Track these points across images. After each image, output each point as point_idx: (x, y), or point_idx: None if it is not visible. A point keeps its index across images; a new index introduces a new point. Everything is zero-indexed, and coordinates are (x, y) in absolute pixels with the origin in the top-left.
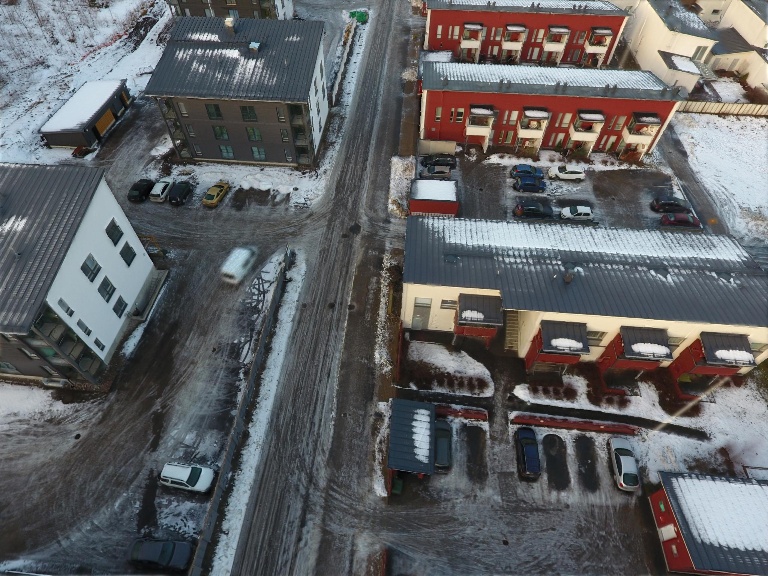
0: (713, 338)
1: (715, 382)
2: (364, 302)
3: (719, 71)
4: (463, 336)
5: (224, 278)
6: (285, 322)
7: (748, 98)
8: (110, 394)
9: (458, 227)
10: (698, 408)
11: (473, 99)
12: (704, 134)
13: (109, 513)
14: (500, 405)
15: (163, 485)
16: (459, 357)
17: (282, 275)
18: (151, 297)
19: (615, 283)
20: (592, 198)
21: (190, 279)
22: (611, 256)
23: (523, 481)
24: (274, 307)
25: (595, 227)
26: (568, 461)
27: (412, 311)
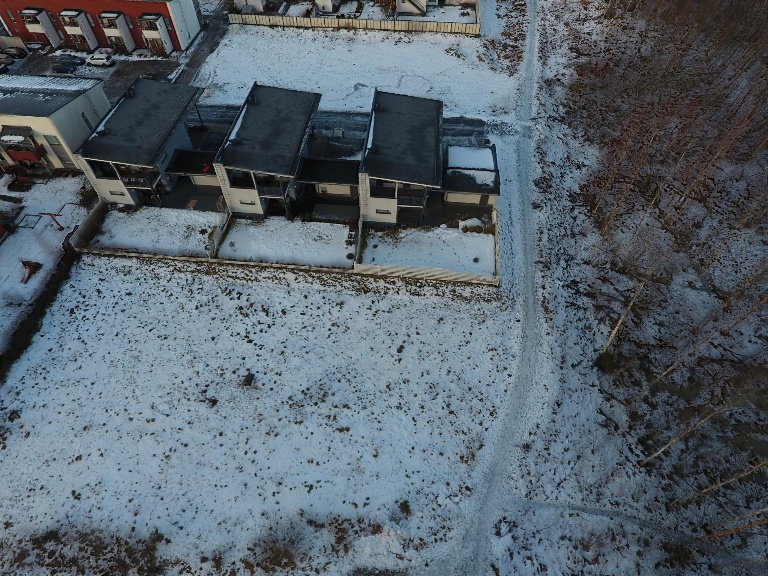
0: (9, 130)
1: (58, 174)
2: None
3: None
4: None
5: None
6: None
7: (305, 15)
8: None
9: None
10: (31, 187)
11: (26, 2)
12: (245, 39)
13: None
14: None
15: None
16: None
17: None
18: None
19: None
20: (106, 77)
21: None
22: None
23: None
24: None
25: None
26: None
27: None
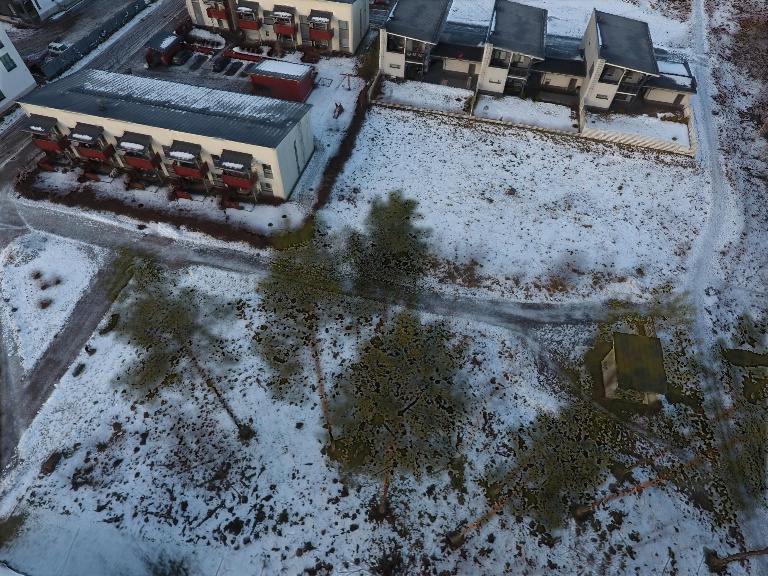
0: (316, 13)
1: (335, 54)
2: (182, 16)
3: None
4: (222, 29)
5: (115, 2)
6: (137, 19)
7: None
8: (39, 29)
9: None
10: (318, 61)
11: None
12: None
13: (24, 58)
14: (223, 52)
15: (51, 54)
16: (214, 35)
17: (144, 1)
18: (73, 2)
19: None
20: None
21: (97, 0)
22: None
23: (214, 72)
24: (134, 12)
25: None
26: (240, 69)
27: (192, 7)
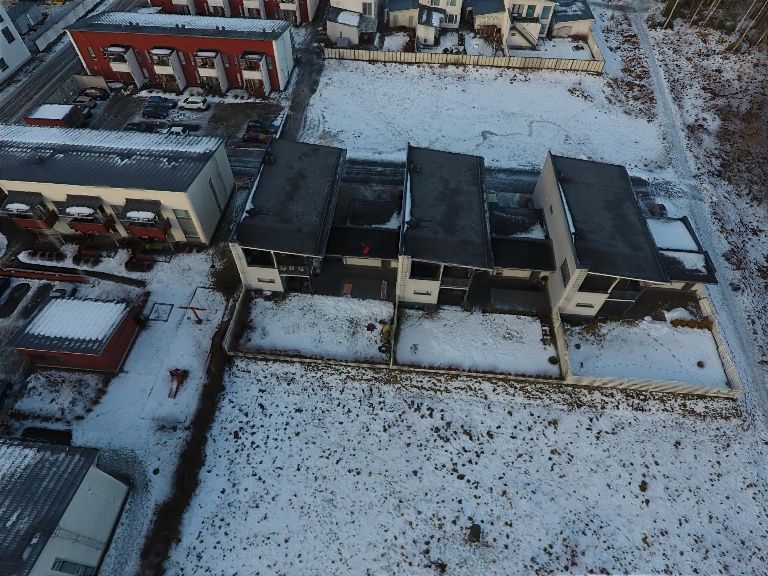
0: (134, 203)
1: (180, 249)
2: None
3: (400, 27)
4: (5, 218)
5: None
6: None
7: (404, 48)
8: None
9: (4, 129)
10: (152, 266)
11: (111, 39)
12: (345, 77)
13: None
14: (0, 264)
15: None
16: None
17: None
18: None
19: (75, 164)
20: (204, 123)
21: None
22: (100, 148)
23: None
24: None
25: (119, 131)
26: (23, 300)
27: None
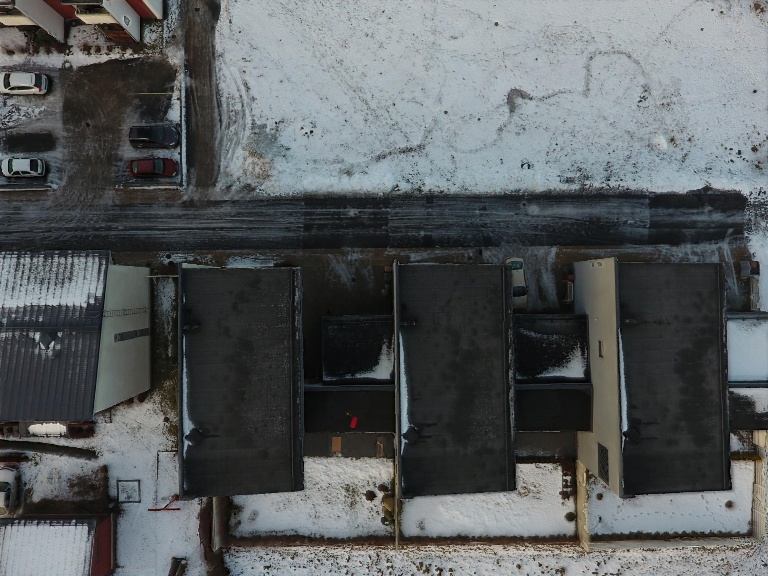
0: None
1: None
2: None
3: None
4: None
5: None
6: None
7: None
8: None
9: None
10: (93, 429)
11: None
12: None
13: None
14: None
15: None
16: None
17: None
18: None
19: None
20: (57, 127)
21: None
22: None
23: None
24: None
25: None
26: None
27: None
